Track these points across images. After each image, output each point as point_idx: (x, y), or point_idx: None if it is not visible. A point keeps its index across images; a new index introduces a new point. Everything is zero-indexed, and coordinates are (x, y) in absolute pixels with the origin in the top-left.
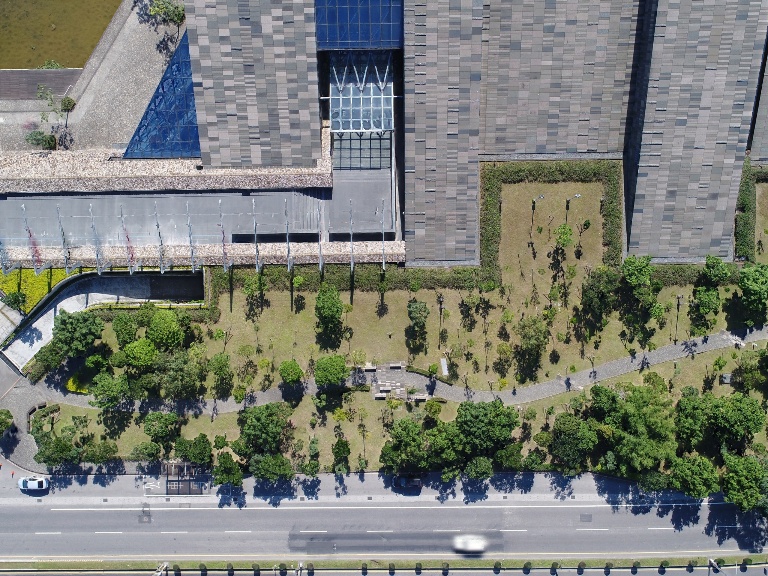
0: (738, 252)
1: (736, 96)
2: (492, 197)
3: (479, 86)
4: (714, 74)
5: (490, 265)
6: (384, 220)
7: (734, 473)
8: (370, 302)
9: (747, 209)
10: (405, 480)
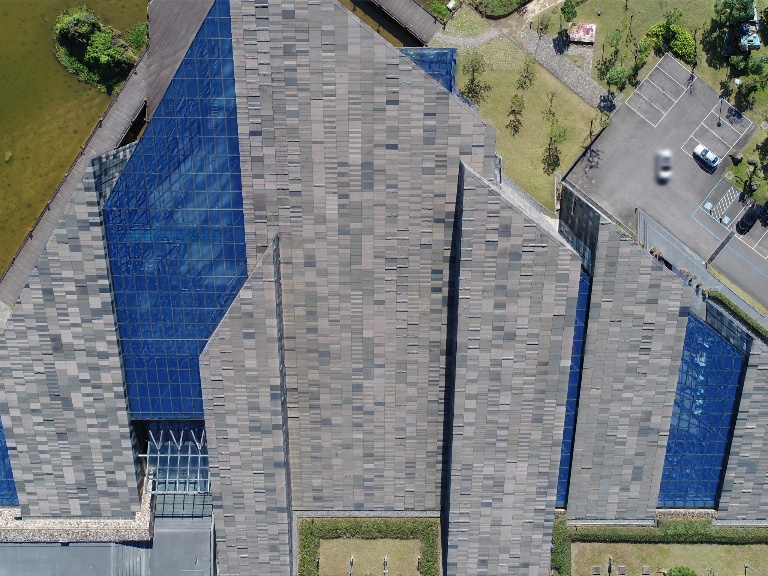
0: None
1: (539, 484)
2: (309, 554)
3: (283, 472)
4: (515, 466)
5: None
6: (204, 570)
7: None
8: None
9: (562, 571)
10: None
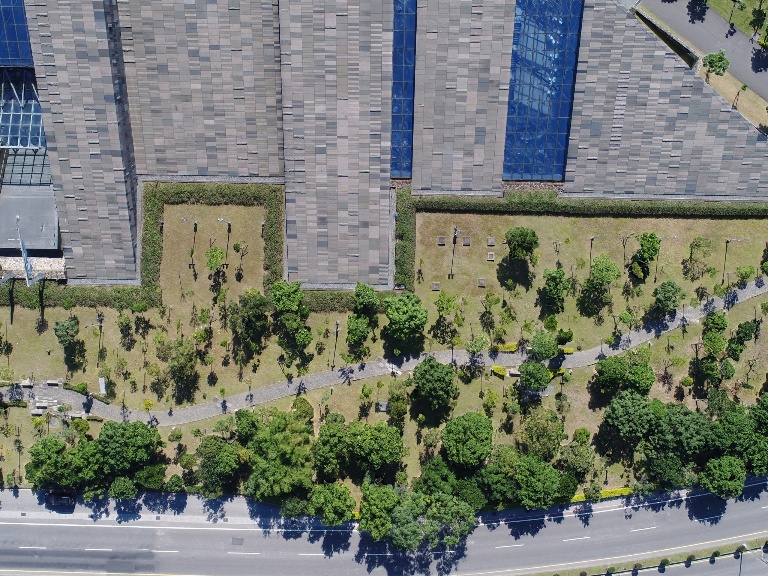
0: (396, 280)
1: (371, 126)
2: (152, 217)
3: (114, 108)
4: (346, 103)
5: (149, 285)
6: (50, 237)
7: (367, 502)
8: (30, 318)
9: (405, 238)
10: (54, 497)
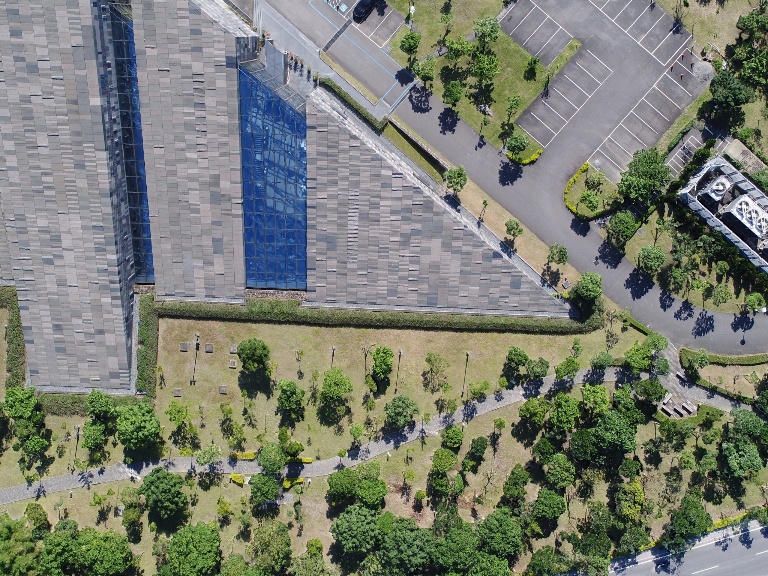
0: (137, 386)
1: (95, 240)
2: None
3: None
4: (68, 218)
5: None
6: None
7: None
8: None
9: (145, 344)
10: None
